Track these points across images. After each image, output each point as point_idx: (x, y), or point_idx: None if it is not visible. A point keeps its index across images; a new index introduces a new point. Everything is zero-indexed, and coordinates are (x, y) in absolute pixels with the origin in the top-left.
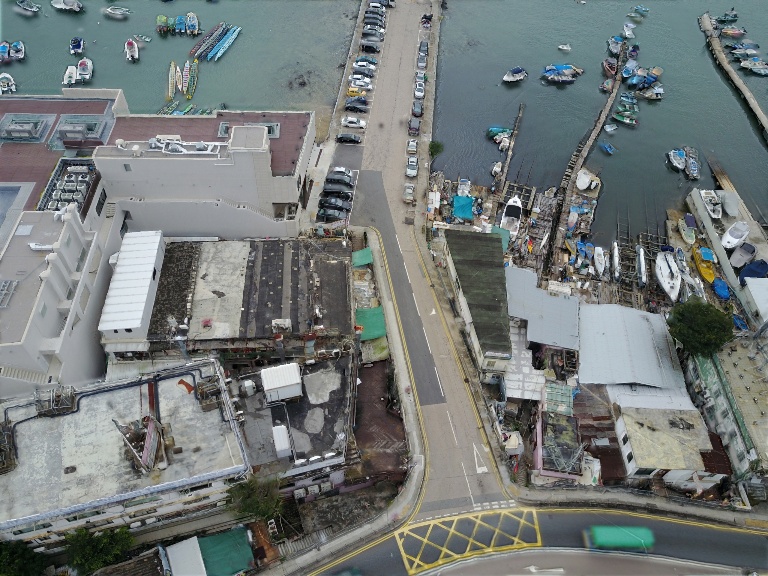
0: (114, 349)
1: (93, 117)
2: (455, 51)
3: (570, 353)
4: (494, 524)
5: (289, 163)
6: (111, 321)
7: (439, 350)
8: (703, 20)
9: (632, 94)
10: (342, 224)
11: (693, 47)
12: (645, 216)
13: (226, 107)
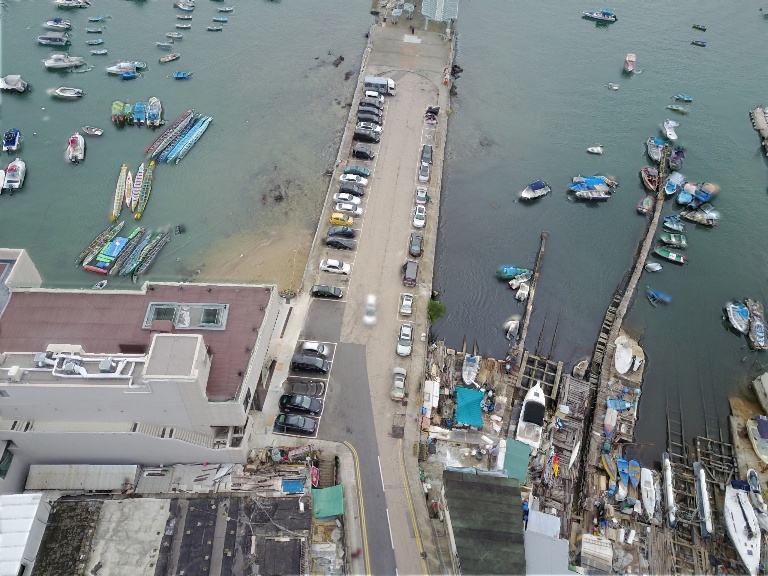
0: None
1: None
2: (465, 153)
3: None
4: None
5: (234, 375)
6: None
7: None
8: (756, 115)
9: (677, 218)
10: (305, 450)
11: (745, 148)
12: (702, 408)
13: (182, 231)
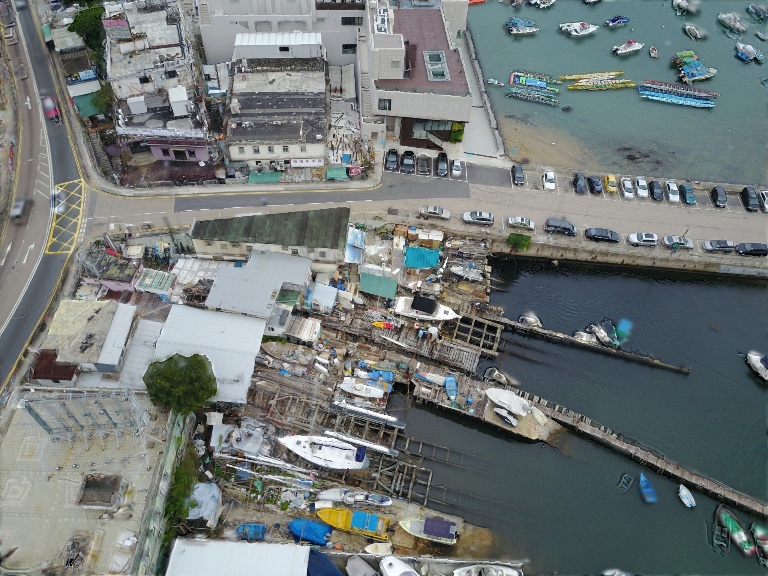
0: (234, 51)
1: (439, 0)
2: None
3: (204, 300)
4: (70, 229)
5: (395, 88)
6: (242, 36)
7: (226, 213)
8: None
9: None
10: None
11: None
12: (470, 491)
13: (565, 110)
